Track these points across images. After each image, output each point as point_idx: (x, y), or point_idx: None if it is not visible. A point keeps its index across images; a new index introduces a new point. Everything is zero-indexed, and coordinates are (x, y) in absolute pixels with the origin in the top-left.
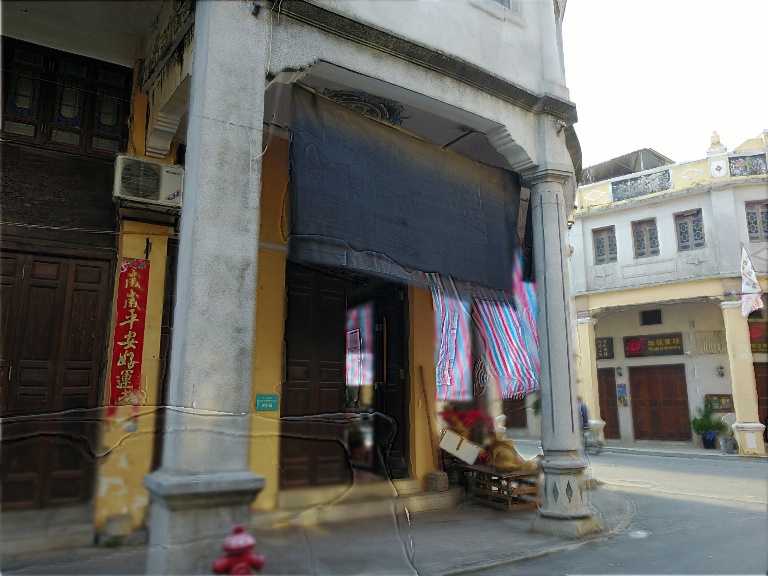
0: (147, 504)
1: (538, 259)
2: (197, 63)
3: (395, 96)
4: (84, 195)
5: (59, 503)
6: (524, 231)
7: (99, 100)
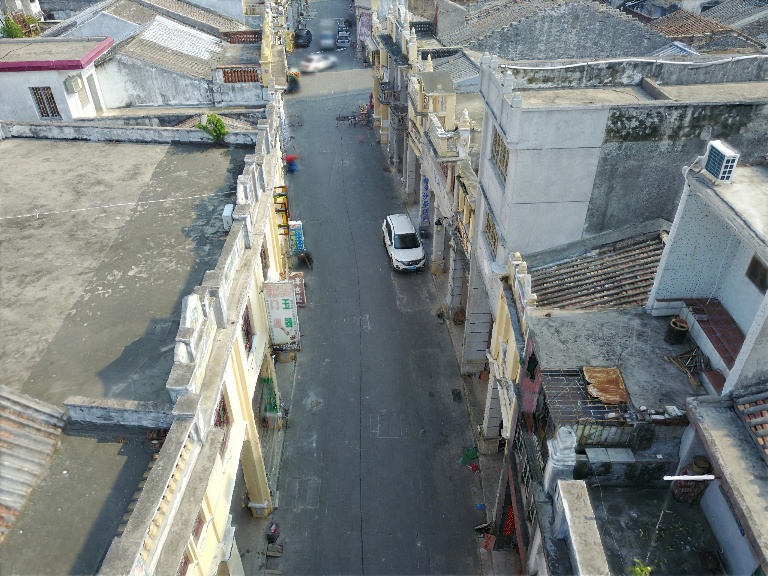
0: None
1: None
2: None
3: None
4: None
5: None
6: None
7: None
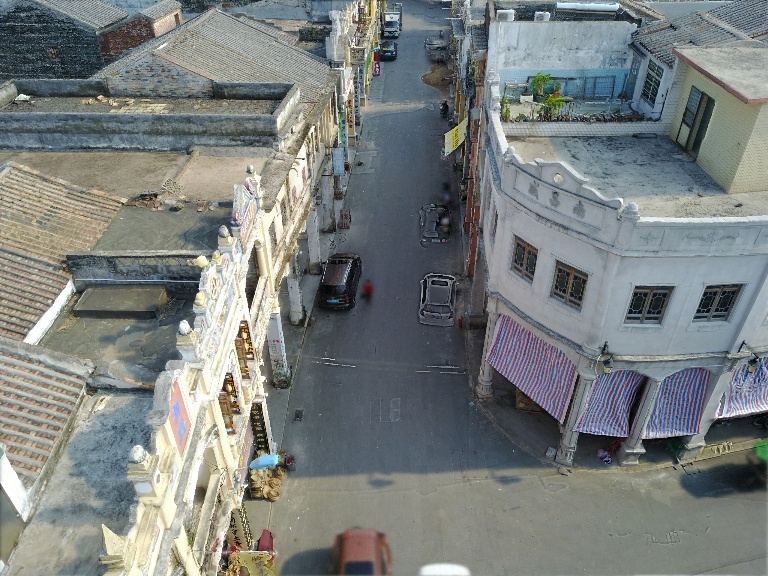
0: None
1: None
2: None
3: None
4: None
5: None
6: None
7: None
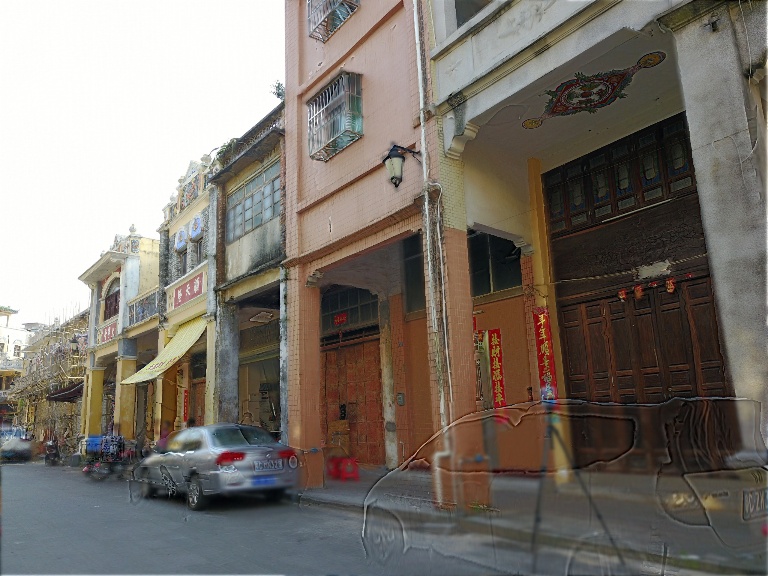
0: (526, 451)
1: None
2: None
3: None
4: None
5: None
6: None
7: None
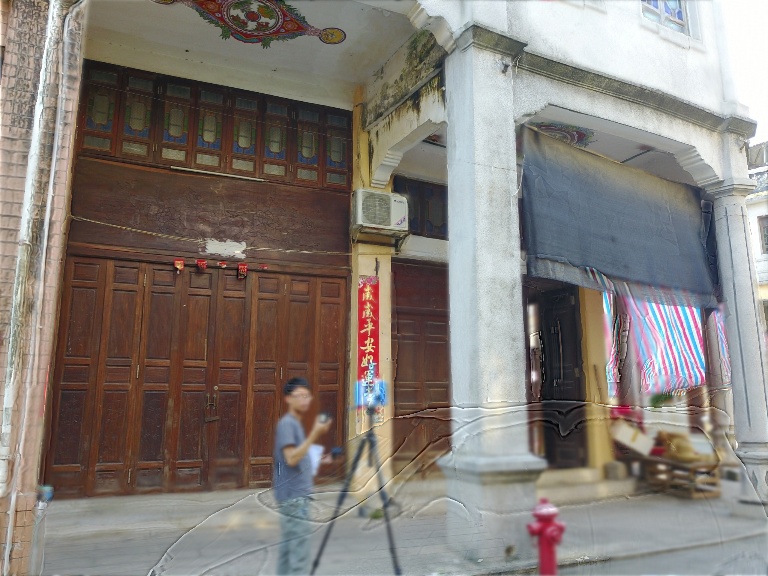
0: (604, 469)
1: (725, 267)
2: (458, 117)
3: (603, 128)
4: (324, 223)
5: (562, 466)
6: (706, 241)
7: (329, 141)
